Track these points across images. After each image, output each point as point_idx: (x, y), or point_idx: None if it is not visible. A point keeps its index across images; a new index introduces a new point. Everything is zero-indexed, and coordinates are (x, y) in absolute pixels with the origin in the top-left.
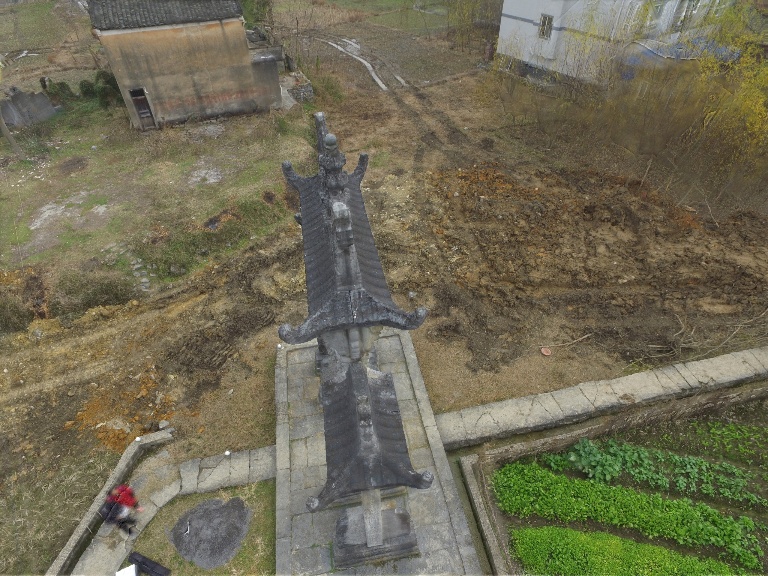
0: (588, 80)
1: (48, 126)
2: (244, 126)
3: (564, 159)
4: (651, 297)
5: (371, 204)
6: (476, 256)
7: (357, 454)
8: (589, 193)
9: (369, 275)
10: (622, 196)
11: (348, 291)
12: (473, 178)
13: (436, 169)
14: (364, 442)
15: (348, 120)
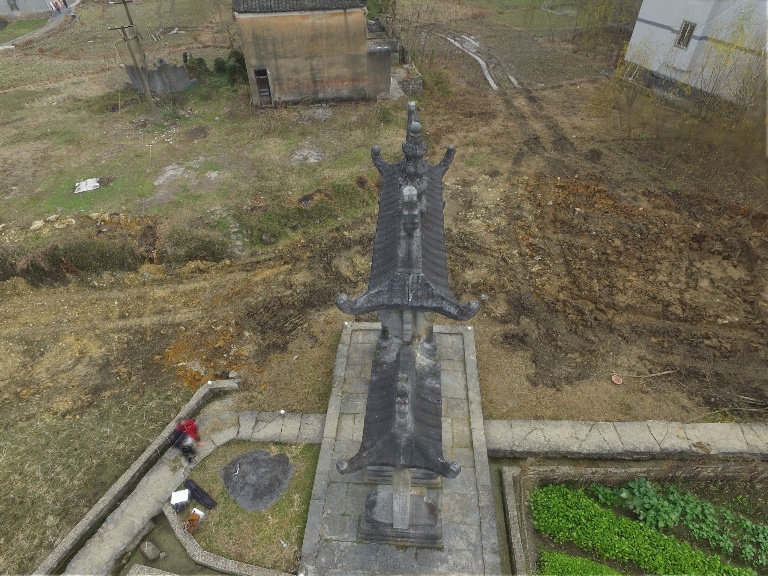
0: (724, 97)
1: (183, 96)
2: (351, 112)
3: (680, 181)
4: (754, 344)
5: (460, 202)
6: (559, 269)
7: (391, 430)
8: (702, 221)
9: (432, 263)
10: (742, 229)
11: (408, 274)
12: (572, 189)
13: (534, 175)
14: (398, 419)
15: (452, 116)
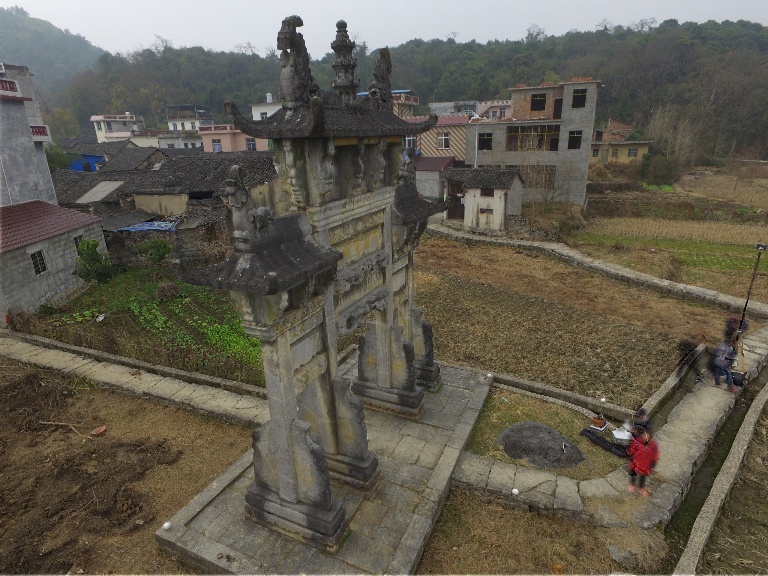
0: None
1: None
2: None
3: None
4: None
5: None
6: None
7: None
8: None
9: None
10: None
11: None
12: None
13: None
14: None
15: None
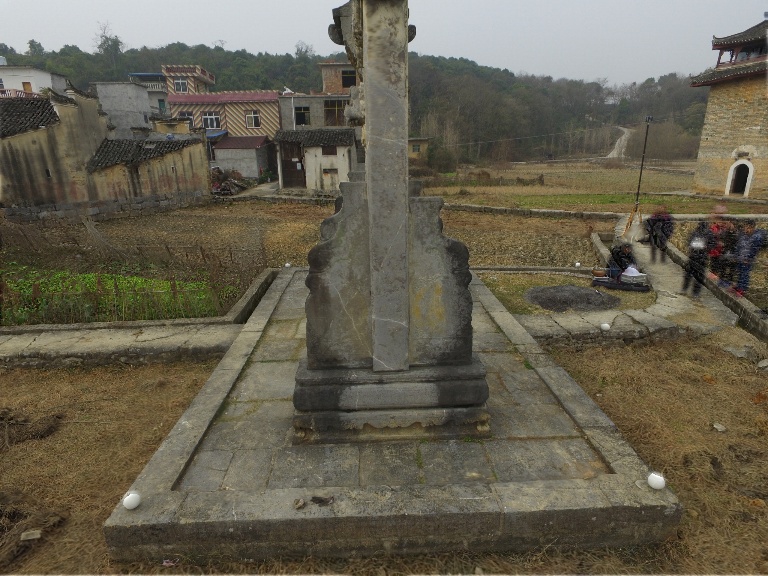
0: None
1: None
2: None
3: None
4: None
5: None
6: None
7: None
8: None
9: None
10: None
11: None
12: None
13: None
14: None
15: None
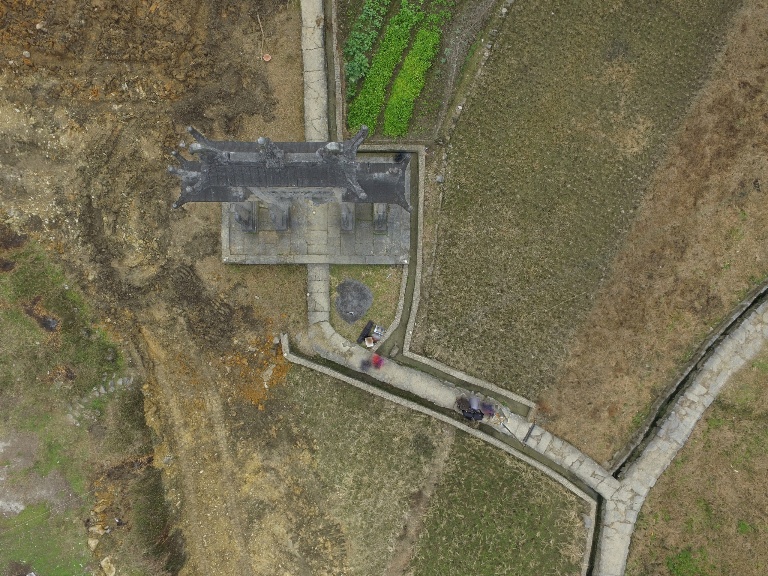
0: None
1: None
2: None
3: None
4: None
5: (23, 155)
6: (139, 70)
7: None
8: None
9: None
10: None
11: None
12: None
13: None
14: None
15: None
